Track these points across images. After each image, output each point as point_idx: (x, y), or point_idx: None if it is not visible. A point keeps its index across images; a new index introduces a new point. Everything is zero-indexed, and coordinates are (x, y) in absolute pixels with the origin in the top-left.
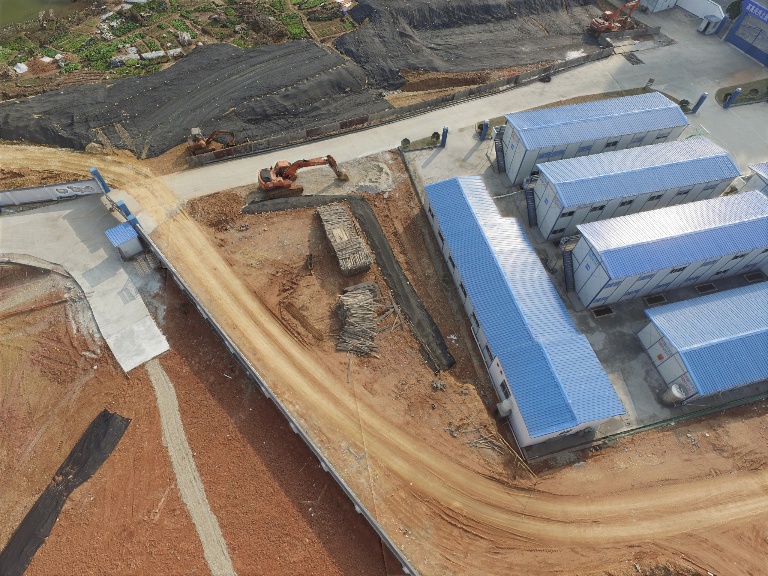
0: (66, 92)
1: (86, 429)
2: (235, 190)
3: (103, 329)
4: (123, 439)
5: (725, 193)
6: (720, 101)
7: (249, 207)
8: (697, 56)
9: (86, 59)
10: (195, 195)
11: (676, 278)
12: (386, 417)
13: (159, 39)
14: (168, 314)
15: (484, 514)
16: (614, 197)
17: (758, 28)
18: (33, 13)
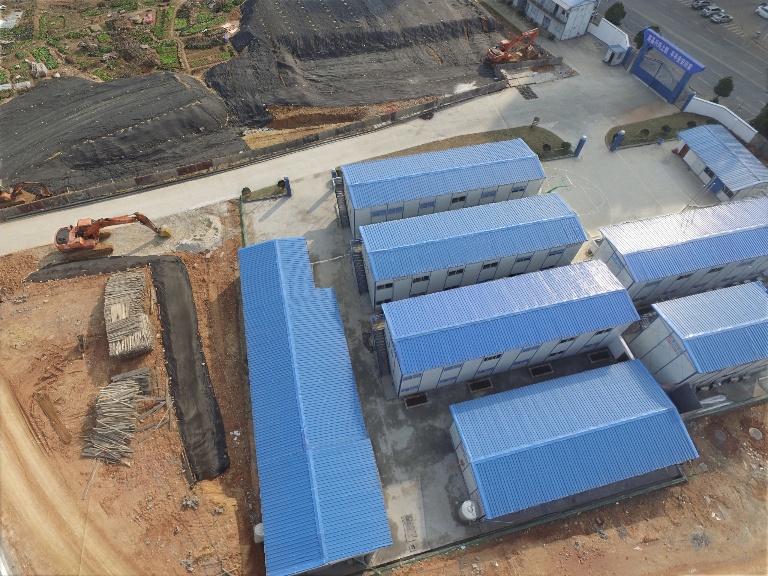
0: None
1: None
2: (33, 251)
3: None
4: None
5: (588, 253)
6: (608, 142)
7: (36, 273)
8: (597, 90)
9: None
10: None
11: (497, 364)
12: (115, 545)
13: (11, 70)
14: None
15: None
16: (435, 268)
17: (659, 61)
18: None
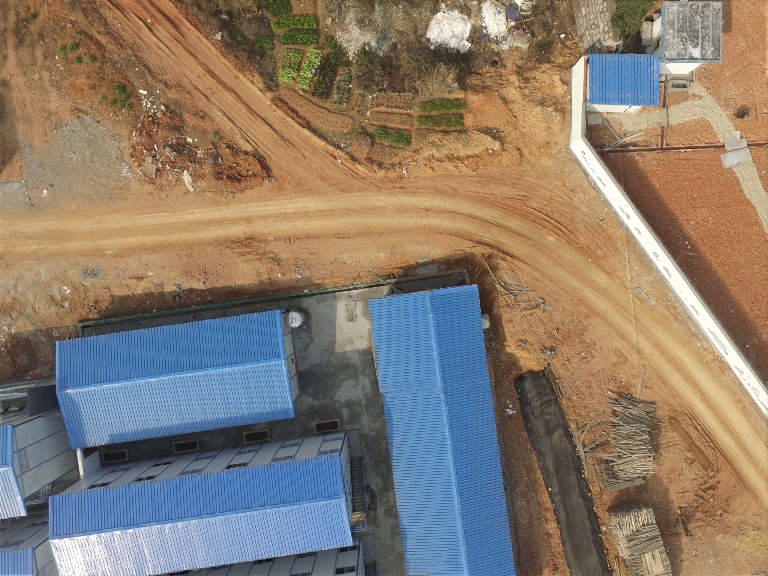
0: None
1: None
2: None
3: None
4: None
5: None
6: None
7: None
8: None
9: None
10: None
11: (233, 459)
12: (608, 325)
13: None
14: None
15: (527, 228)
16: None
17: None
18: None
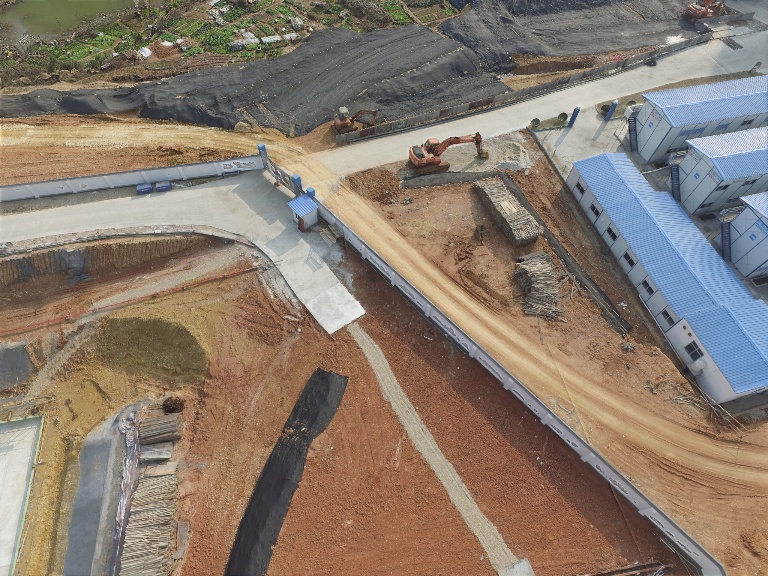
0: (202, 74)
1: (304, 386)
2: (386, 167)
3: (299, 295)
4: (346, 395)
5: None
6: None
7: (407, 182)
8: None
9: (206, 43)
10: (350, 171)
11: None
12: (586, 376)
13: (272, 24)
14: (356, 281)
15: (699, 464)
16: None
17: None
18: (123, 1)
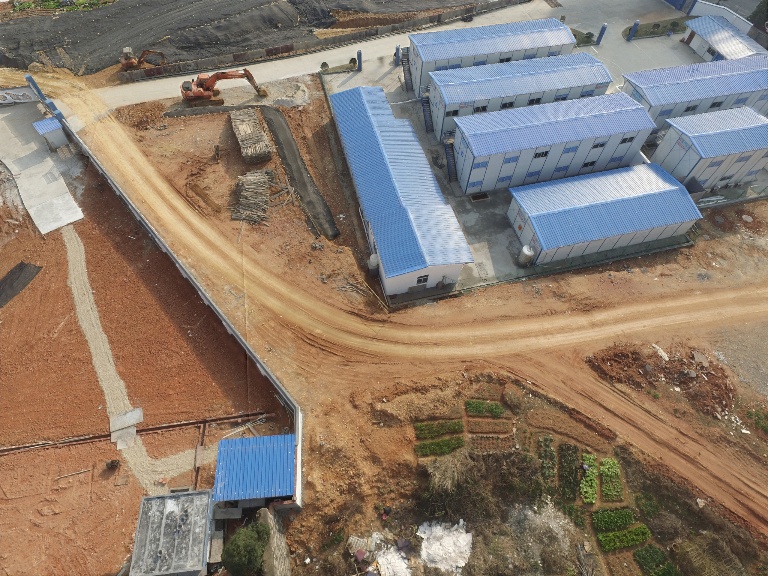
0: (15, 22)
1: (4, 276)
2: (161, 101)
3: (26, 202)
4: (33, 281)
5: None
6: (625, 35)
7: (170, 112)
8: (613, 0)
9: None
10: (123, 104)
11: (544, 165)
12: (267, 268)
13: None
14: (86, 192)
15: (341, 338)
16: (492, 97)
17: None
18: None
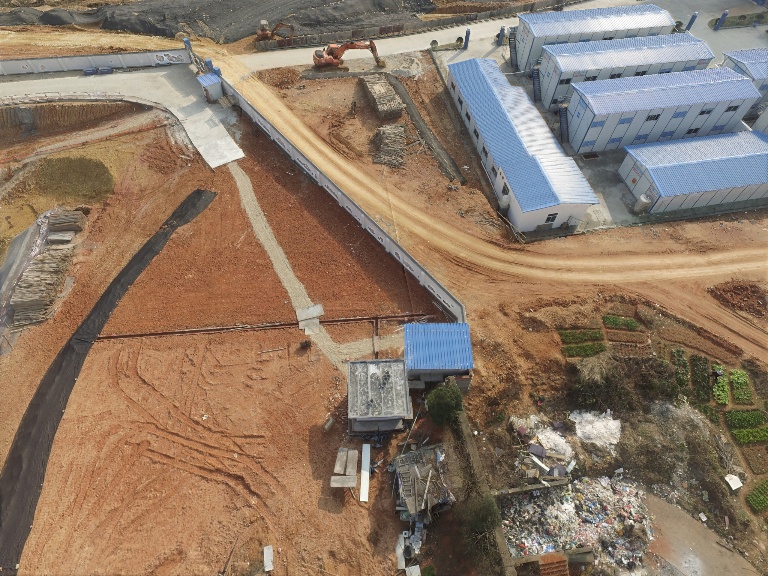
0: None
1: (184, 200)
2: (294, 67)
3: (195, 142)
4: (212, 203)
5: None
6: (711, 26)
7: (306, 75)
8: None
9: None
10: (262, 68)
11: (653, 129)
12: (411, 203)
13: None
14: (243, 136)
15: (483, 262)
16: (604, 67)
17: None
18: None
